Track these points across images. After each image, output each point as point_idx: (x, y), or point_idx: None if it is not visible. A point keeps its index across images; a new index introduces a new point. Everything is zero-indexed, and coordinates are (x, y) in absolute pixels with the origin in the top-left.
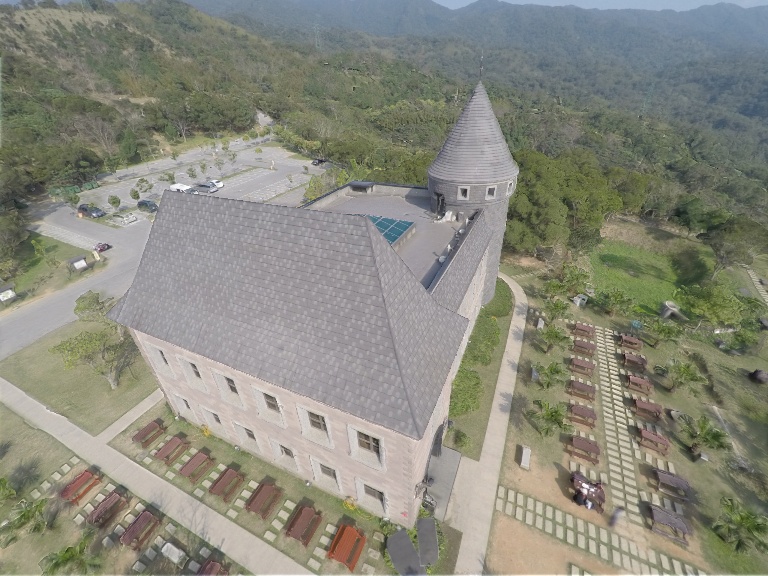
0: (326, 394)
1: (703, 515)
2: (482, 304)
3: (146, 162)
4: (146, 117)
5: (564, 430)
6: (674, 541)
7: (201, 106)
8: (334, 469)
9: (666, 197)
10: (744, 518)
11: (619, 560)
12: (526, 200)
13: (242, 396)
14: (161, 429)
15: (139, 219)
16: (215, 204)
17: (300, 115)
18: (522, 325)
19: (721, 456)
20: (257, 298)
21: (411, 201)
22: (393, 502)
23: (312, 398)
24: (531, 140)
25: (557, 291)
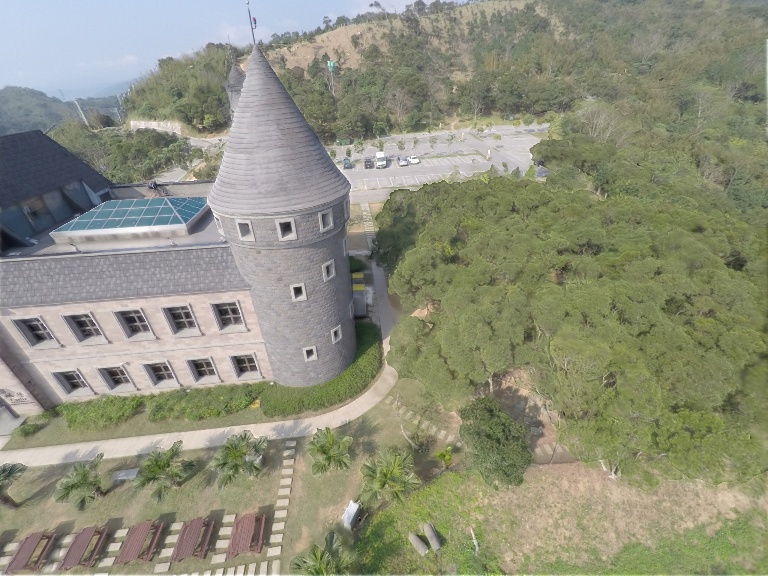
0: None
1: None
2: (276, 380)
3: (403, 131)
4: (455, 93)
5: None
6: None
7: (505, 86)
8: None
9: None
10: None
11: None
12: (463, 295)
13: None
14: None
15: None
16: None
17: None
18: None
19: None
20: None
21: None
22: None
23: None
24: None
25: None
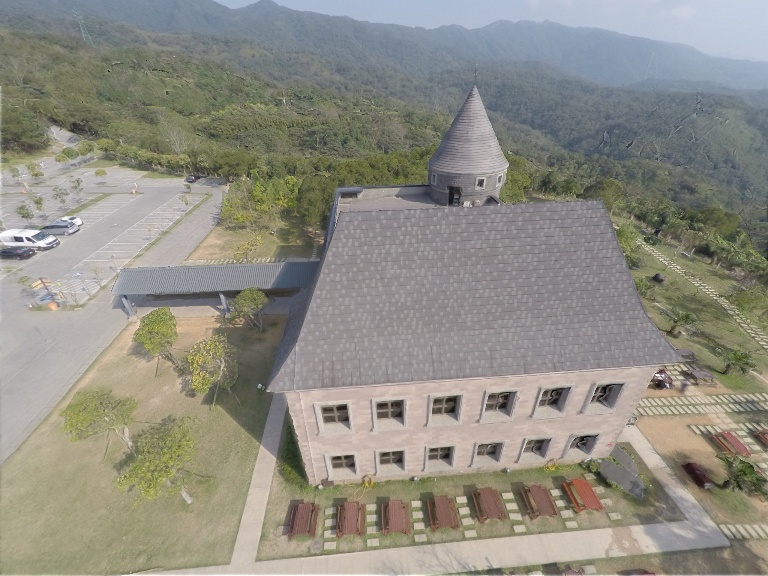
0: (598, 360)
1: (705, 365)
2: None
3: None
4: None
5: None
6: (710, 386)
7: None
8: (551, 438)
9: (529, 173)
10: (735, 354)
11: (702, 410)
12: None
13: (463, 410)
14: (313, 507)
15: None
16: (425, 216)
17: (134, 125)
18: None
19: (682, 330)
20: (496, 300)
21: (408, 199)
22: (603, 439)
23: (588, 368)
24: (370, 139)
25: None
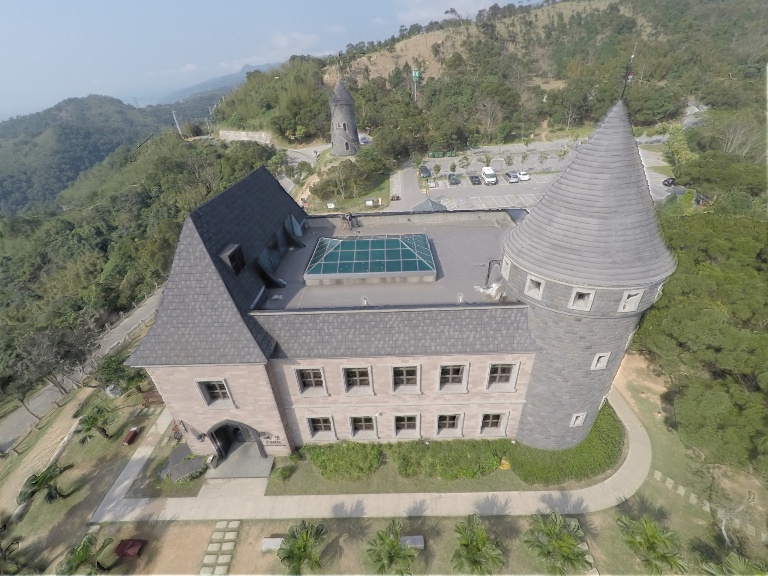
0: None
1: None
2: (518, 439)
3: (500, 143)
4: (546, 102)
5: (289, 572)
6: None
7: (605, 94)
8: None
9: None
10: None
11: None
12: None
13: None
14: None
15: (438, 187)
16: None
17: (725, 115)
18: (517, 509)
19: None
20: None
21: None
22: None
23: None
24: None
25: (642, 549)
